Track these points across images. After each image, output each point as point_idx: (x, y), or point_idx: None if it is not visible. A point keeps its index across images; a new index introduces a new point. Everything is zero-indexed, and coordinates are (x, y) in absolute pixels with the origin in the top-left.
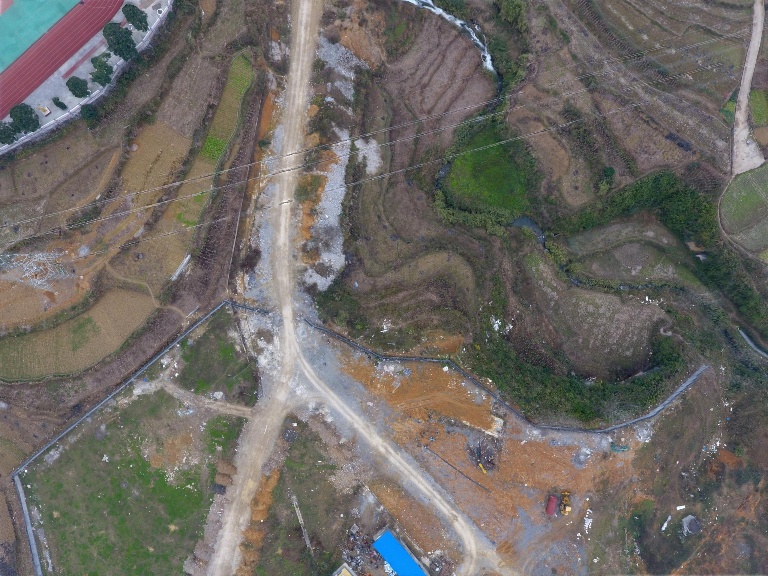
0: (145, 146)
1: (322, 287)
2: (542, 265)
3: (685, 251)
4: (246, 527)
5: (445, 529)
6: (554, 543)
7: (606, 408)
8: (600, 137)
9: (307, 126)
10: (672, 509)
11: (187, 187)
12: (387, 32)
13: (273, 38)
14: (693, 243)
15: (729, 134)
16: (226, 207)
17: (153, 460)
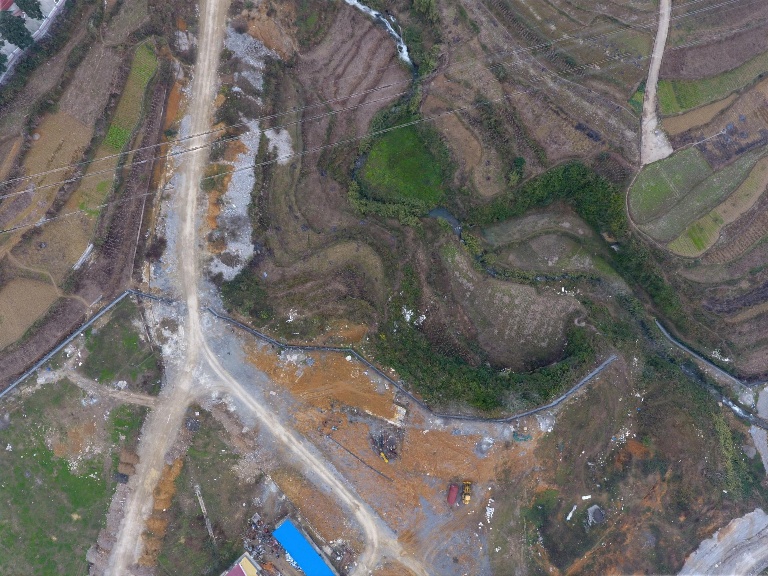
0: (47, 135)
1: (228, 277)
2: (458, 256)
3: (601, 242)
4: (148, 516)
5: (347, 518)
6: (456, 532)
7: (507, 397)
8: (511, 127)
9: (214, 116)
10: (578, 499)
11: None
12: (298, 22)
13: (180, 28)
14: (606, 234)
15: (638, 124)
16: (130, 196)
17: (56, 449)
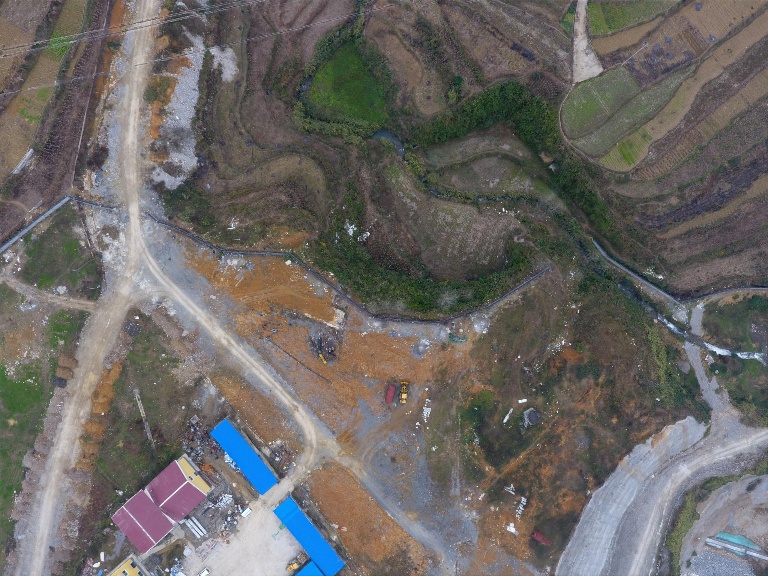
0: None
1: (170, 186)
2: (402, 177)
3: (539, 164)
4: (86, 420)
5: (286, 419)
6: (393, 432)
7: (442, 298)
8: (450, 48)
9: (157, 29)
10: (514, 402)
11: (31, 83)
12: None
13: None
14: (543, 153)
15: (570, 45)
16: (71, 104)
17: None
